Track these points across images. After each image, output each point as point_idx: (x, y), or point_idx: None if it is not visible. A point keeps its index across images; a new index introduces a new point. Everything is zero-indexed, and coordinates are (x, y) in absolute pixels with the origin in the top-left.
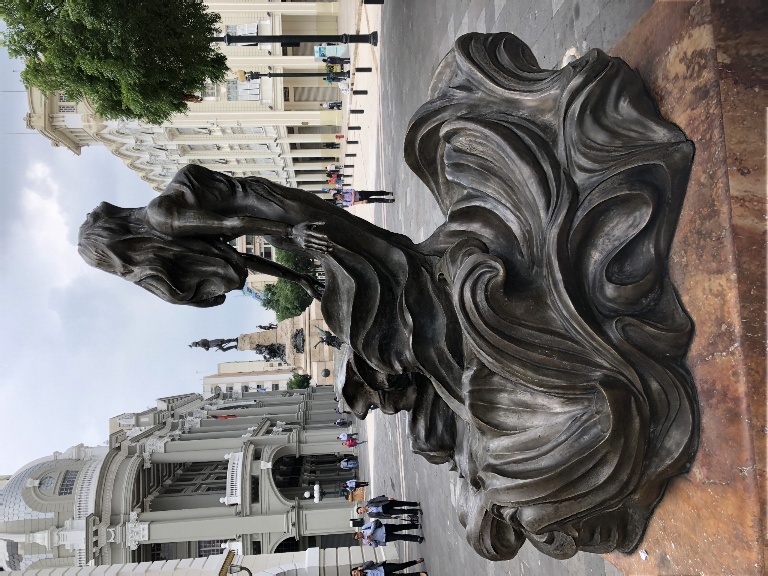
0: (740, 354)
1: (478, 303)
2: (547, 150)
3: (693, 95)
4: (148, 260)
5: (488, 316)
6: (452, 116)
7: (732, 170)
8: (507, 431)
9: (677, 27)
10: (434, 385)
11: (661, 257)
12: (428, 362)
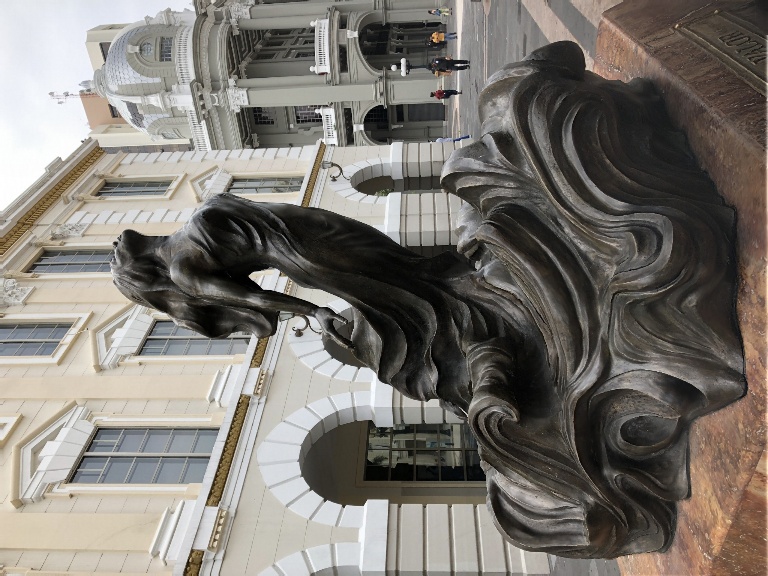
0: (710, 565)
1: (491, 428)
2: (590, 305)
3: (766, 350)
4: (182, 310)
5: (499, 438)
6: (498, 183)
7: (767, 453)
8: (511, 479)
9: None
10: None
11: (685, 421)
12: (452, 396)
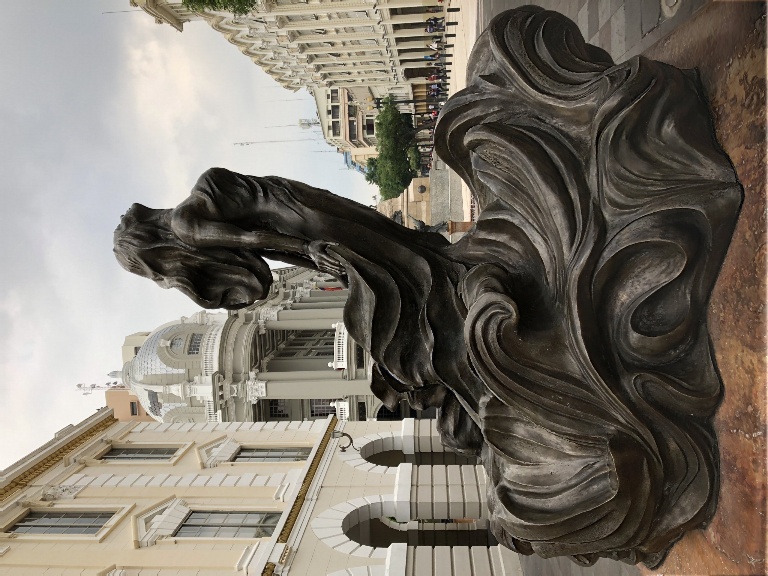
0: (762, 444)
1: (490, 343)
2: (577, 173)
3: (748, 131)
4: (176, 269)
5: (500, 357)
6: (483, 112)
7: None
8: (521, 461)
9: (741, 37)
10: (457, 397)
11: (699, 304)
12: (450, 376)
